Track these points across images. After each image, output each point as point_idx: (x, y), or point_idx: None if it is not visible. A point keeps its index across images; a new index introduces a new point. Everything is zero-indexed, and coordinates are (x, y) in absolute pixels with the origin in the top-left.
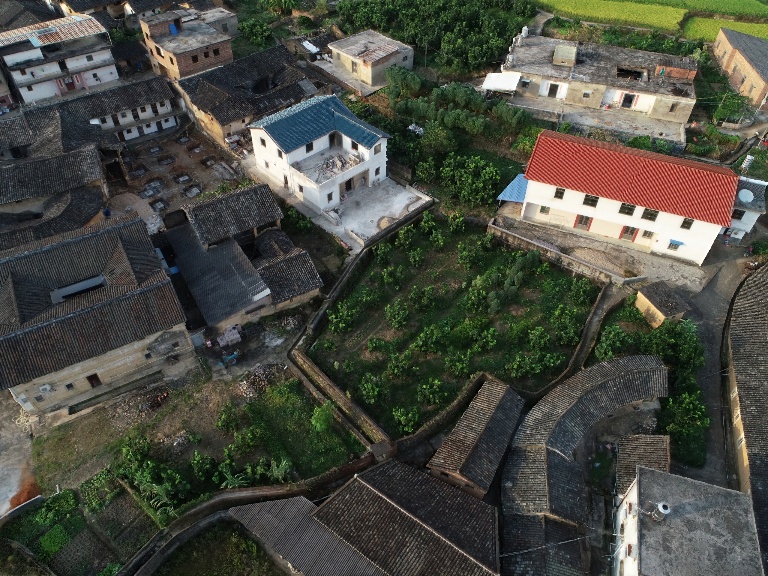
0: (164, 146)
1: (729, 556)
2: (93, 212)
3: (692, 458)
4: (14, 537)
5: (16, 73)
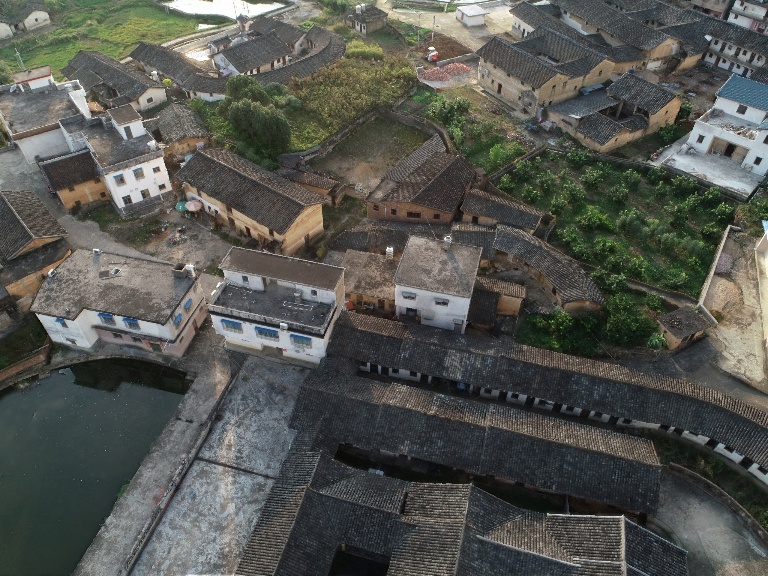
0: (723, 80)
1: (425, 275)
2: (620, 59)
3: (521, 336)
4: (418, 90)
5: (738, 2)
